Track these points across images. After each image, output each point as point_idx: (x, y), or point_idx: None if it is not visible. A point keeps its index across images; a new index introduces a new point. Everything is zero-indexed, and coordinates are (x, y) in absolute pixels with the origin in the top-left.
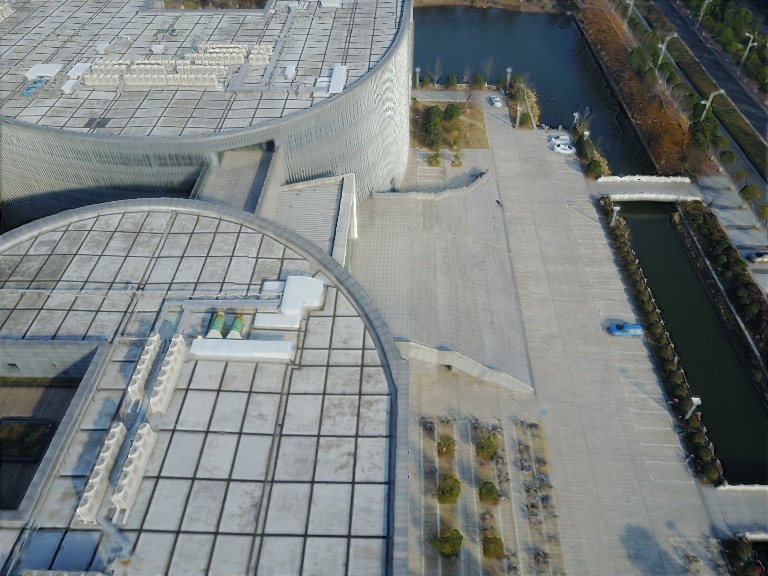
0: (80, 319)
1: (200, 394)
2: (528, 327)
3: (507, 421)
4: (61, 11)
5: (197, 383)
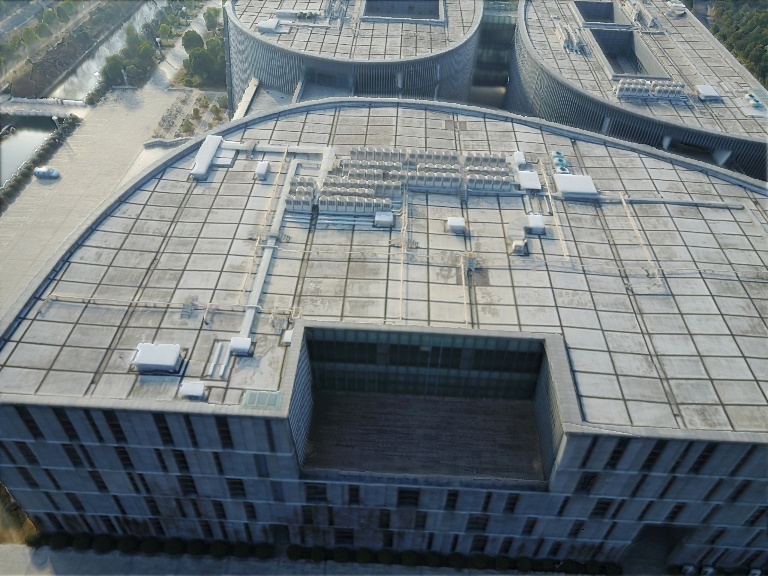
0: (380, 27)
1: (314, 8)
2: (118, 180)
3: (169, 139)
4: (730, 356)
5: (316, 10)
